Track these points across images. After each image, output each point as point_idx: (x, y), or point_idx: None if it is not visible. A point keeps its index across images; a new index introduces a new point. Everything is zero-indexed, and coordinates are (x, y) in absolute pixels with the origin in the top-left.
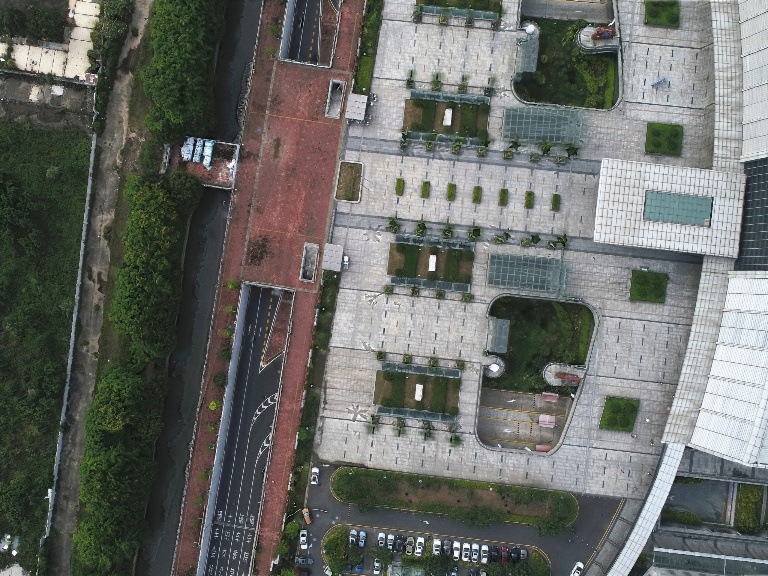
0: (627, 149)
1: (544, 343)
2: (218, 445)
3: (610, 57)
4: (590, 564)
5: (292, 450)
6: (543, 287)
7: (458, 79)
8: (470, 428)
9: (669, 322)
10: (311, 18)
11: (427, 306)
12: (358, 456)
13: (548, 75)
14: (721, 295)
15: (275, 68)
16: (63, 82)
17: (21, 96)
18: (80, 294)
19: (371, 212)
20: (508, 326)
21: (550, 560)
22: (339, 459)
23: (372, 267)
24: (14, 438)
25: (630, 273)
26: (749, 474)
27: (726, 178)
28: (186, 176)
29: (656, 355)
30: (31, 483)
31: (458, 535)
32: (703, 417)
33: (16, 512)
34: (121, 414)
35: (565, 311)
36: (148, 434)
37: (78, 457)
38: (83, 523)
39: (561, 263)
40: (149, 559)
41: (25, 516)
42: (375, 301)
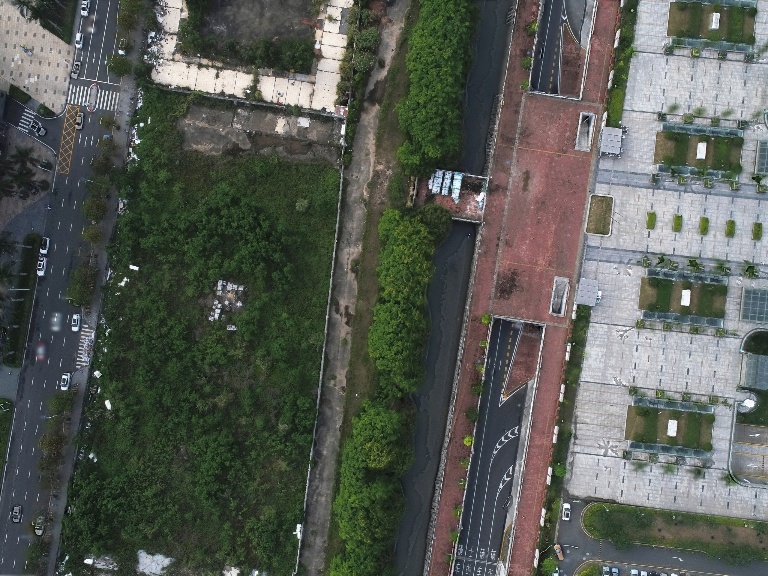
0: None
1: None
2: (467, 480)
3: None
4: None
5: (543, 486)
6: None
7: (710, 112)
8: (723, 464)
9: None
10: (551, 48)
11: (679, 341)
12: (609, 492)
13: None
14: None
15: (524, 100)
16: (310, 114)
17: (267, 128)
18: (327, 328)
19: (622, 246)
20: None
21: None
22: (590, 495)
23: (623, 301)
24: (264, 473)
25: None
26: None
27: None
28: (441, 210)
29: None
30: (280, 518)
31: (711, 572)
32: None
33: (268, 548)
34: (385, 451)
35: None
36: (402, 470)
37: (326, 492)
38: (340, 560)
39: None
40: None
41: (276, 552)
42: (626, 335)
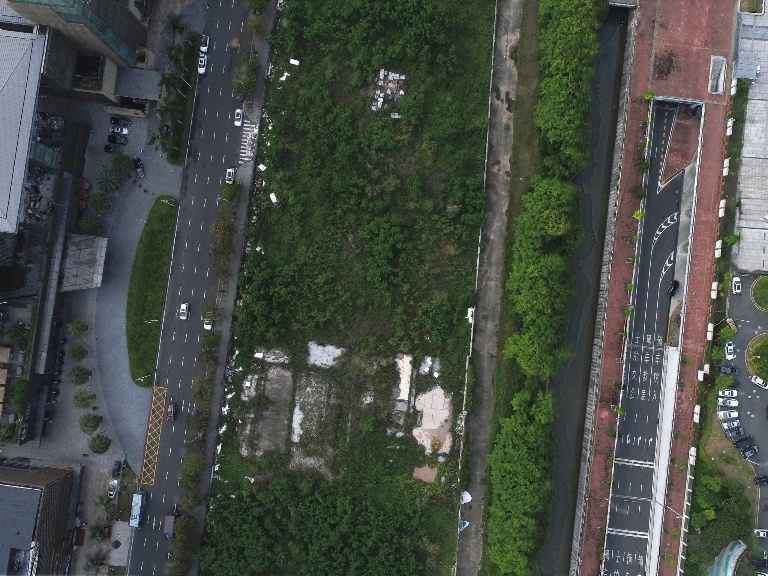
0: None
1: None
2: None
3: None
4: None
5: (711, 261)
6: None
7: None
8: None
9: None
10: None
11: None
12: None
13: None
14: None
15: None
16: None
17: None
18: None
19: None
20: None
21: None
22: (758, 268)
23: None
24: (434, 257)
25: None
26: None
27: None
28: None
29: None
30: (451, 303)
31: None
32: None
33: (442, 330)
34: (563, 218)
35: None
36: (574, 246)
37: (495, 276)
38: (518, 335)
39: None
40: (559, 383)
41: (450, 335)
42: None
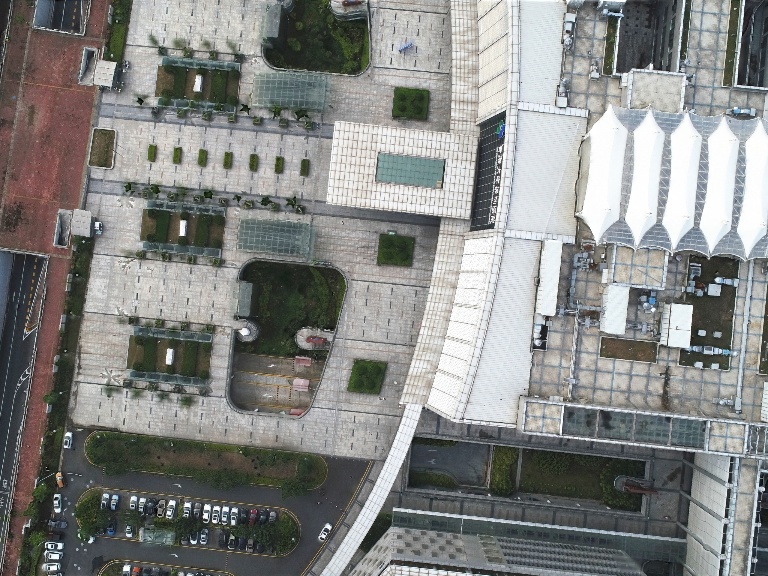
0: (375, 114)
1: (301, 308)
2: None
3: (365, 24)
4: (339, 526)
5: (46, 415)
6: (287, 251)
7: (209, 46)
8: (221, 392)
9: (416, 285)
10: None
11: (179, 271)
12: (112, 420)
13: (305, 42)
14: (458, 257)
15: (29, 36)
16: None
17: None
18: None
19: (124, 178)
20: (251, 289)
21: (300, 522)
22: (93, 423)
23: (125, 233)
24: None
25: (378, 237)
26: (495, 435)
27: (458, 140)
28: None
29: (404, 318)
30: None
31: (210, 498)
32: (436, 377)
33: None
34: None
35: (322, 276)
36: None
37: None
38: None
39: (310, 227)
40: None
41: None
42: (128, 266)
